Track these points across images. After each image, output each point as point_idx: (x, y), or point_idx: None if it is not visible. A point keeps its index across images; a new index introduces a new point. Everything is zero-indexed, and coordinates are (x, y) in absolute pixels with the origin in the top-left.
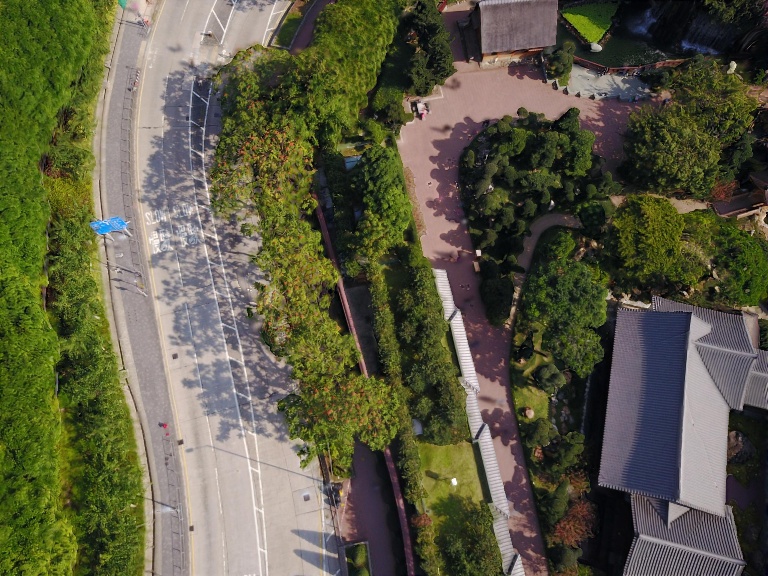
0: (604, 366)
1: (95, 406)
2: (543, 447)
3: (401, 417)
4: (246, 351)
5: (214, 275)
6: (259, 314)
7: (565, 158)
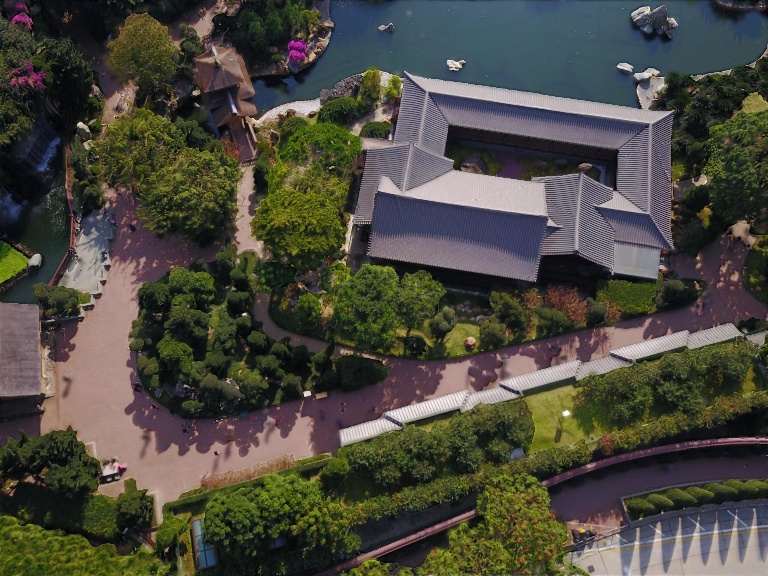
0: None
1: None
2: None
3: (514, 472)
4: None
5: None
6: None
7: (197, 299)
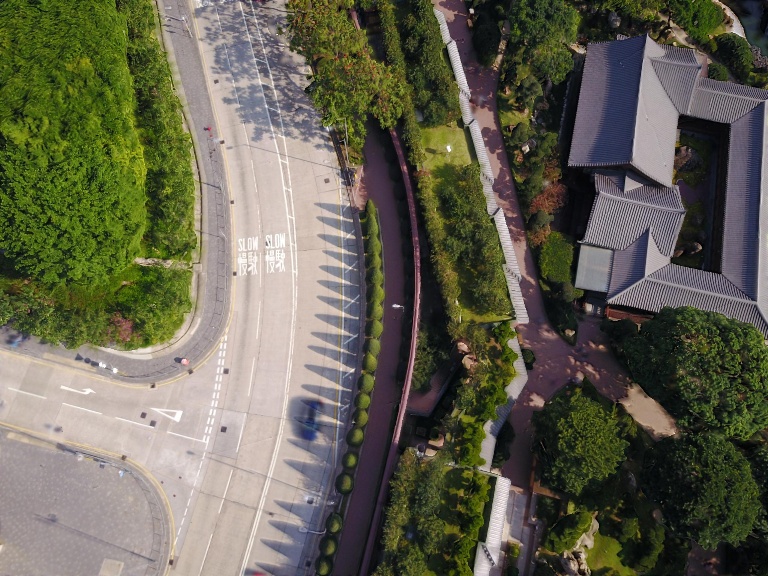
0: (576, 91)
1: (152, 108)
2: (524, 154)
3: (405, 104)
4: (276, 78)
5: (248, 24)
6: (288, 33)
7: None
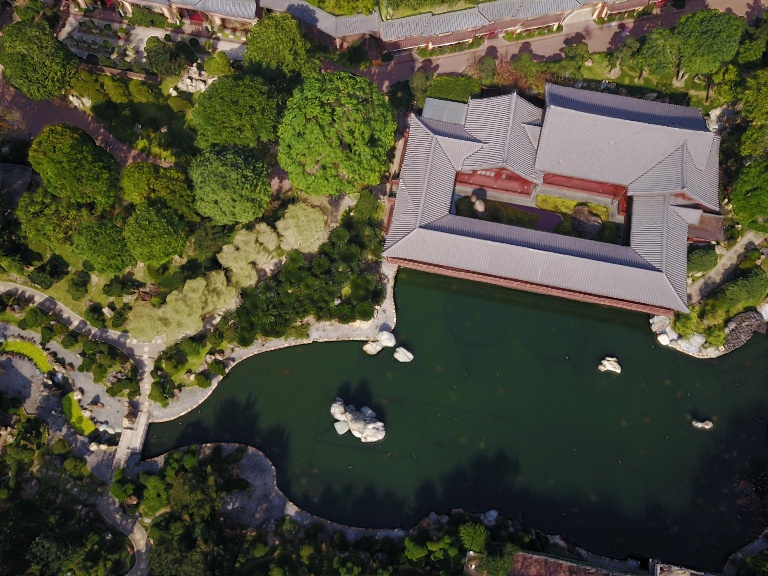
0: None
1: None
2: None
3: None
4: None
5: None
6: None
7: None
